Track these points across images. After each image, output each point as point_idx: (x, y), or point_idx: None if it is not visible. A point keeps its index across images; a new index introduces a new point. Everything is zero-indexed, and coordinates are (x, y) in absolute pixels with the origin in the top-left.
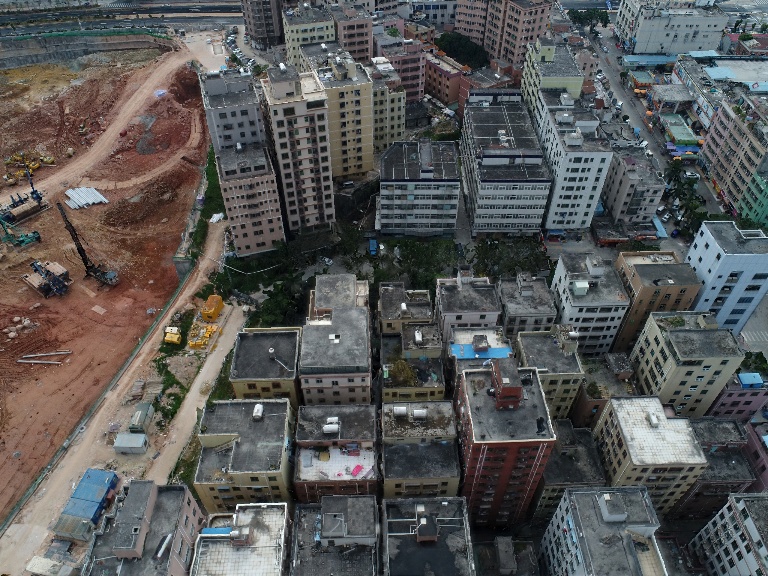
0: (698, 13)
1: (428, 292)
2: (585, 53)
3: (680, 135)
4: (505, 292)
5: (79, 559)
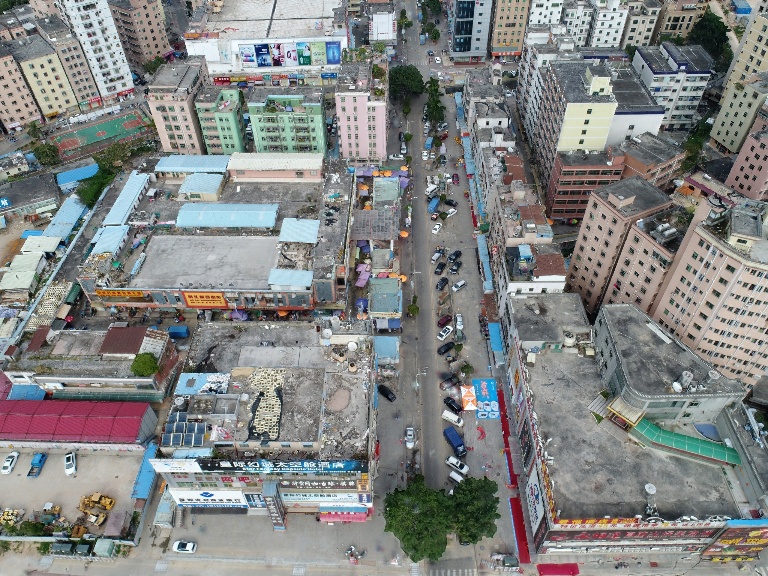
0: (243, 350)
1: (631, 15)
2: (520, 183)
3: (390, 187)
4: (589, 7)
5: (727, 1)
